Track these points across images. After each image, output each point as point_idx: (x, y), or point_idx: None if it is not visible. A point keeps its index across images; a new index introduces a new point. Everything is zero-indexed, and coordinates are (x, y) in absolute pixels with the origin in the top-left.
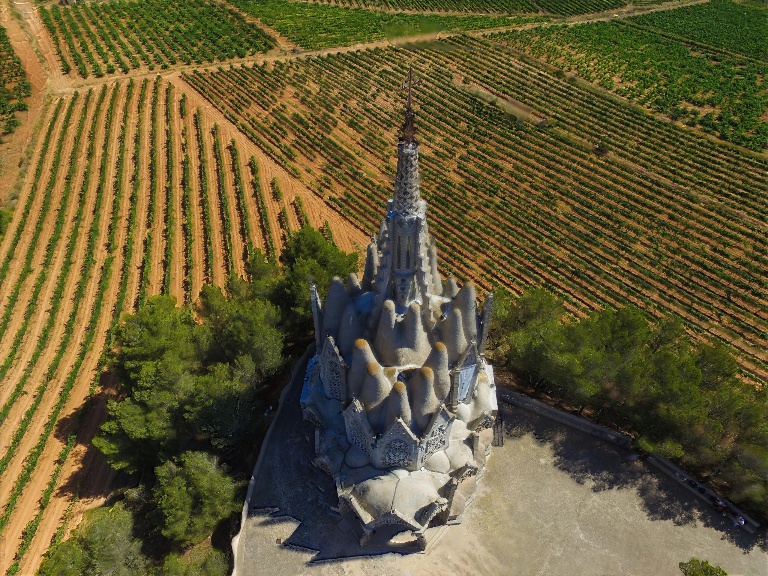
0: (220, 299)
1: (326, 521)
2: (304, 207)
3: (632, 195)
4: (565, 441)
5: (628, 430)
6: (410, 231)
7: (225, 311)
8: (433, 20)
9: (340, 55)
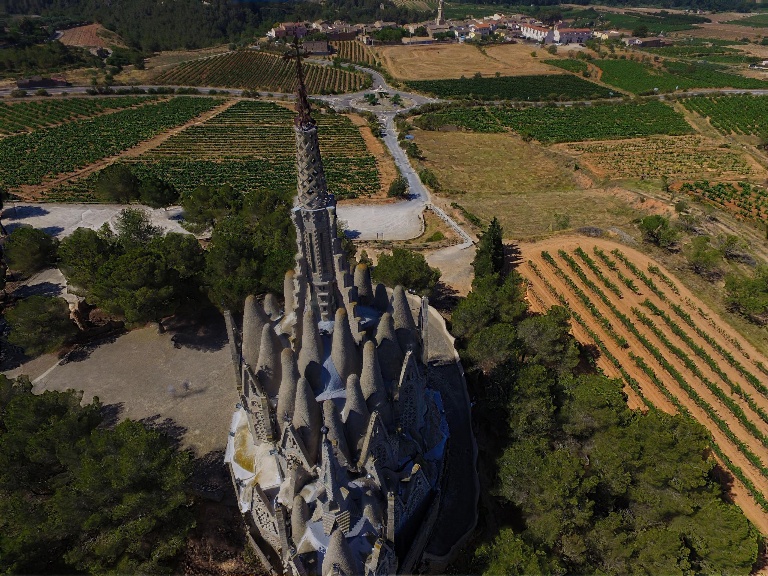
0: (656, 567)
1: None
2: None
3: None
4: None
5: None
6: None
7: None
8: None
9: None
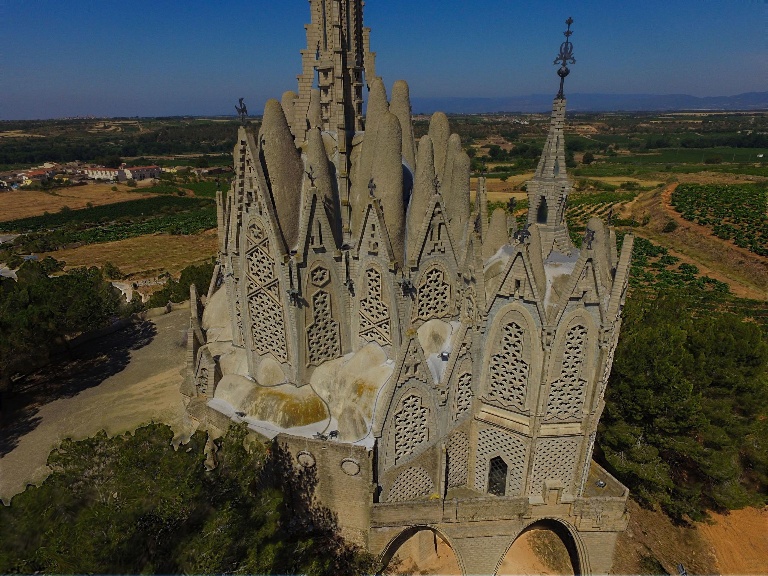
0: None
1: None
2: None
3: None
4: None
5: None
6: None
7: None
8: None
9: None
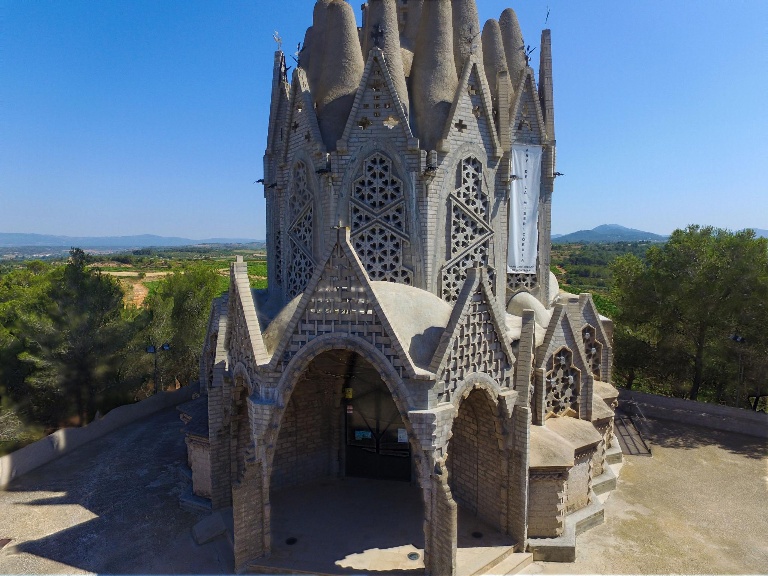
0: None
1: (166, 518)
2: None
3: None
4: None
5: None
6: None
7: None
8: None
9: None
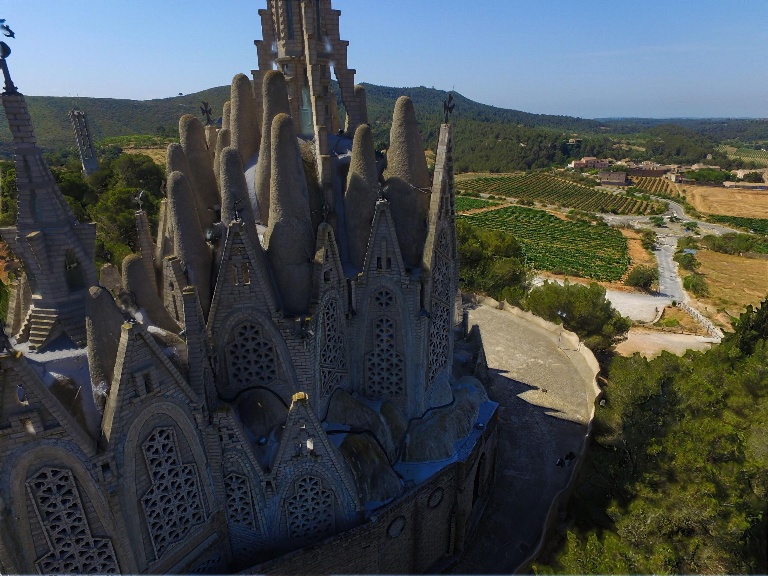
0: None
1: None
2: None
3: None
4: None
5: None
6: None
7: None
8: None
9: None
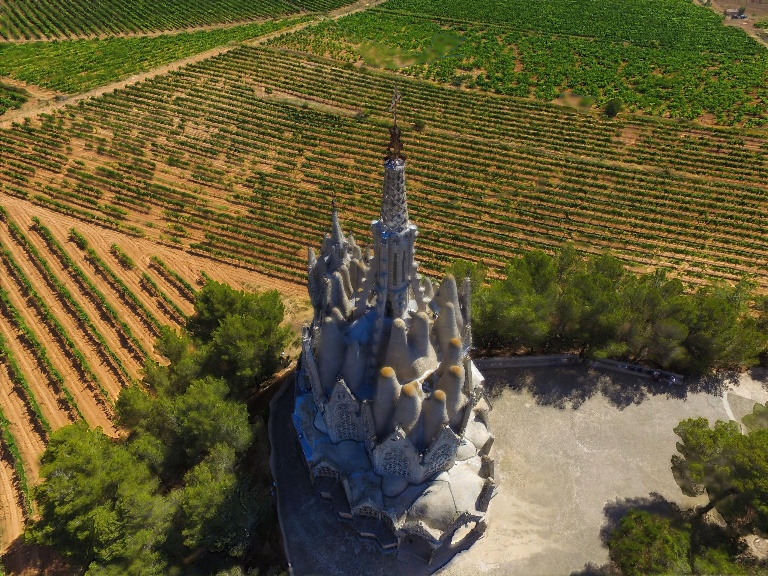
0: (142, 399)
1: (384, 562)
2: (166, 265)
3: (461, 158)
4: (534, 380)
5: (567, 349)
6: (405, 245)
7: (157, 409)
8: (201, 36)
9: (118, 92)
